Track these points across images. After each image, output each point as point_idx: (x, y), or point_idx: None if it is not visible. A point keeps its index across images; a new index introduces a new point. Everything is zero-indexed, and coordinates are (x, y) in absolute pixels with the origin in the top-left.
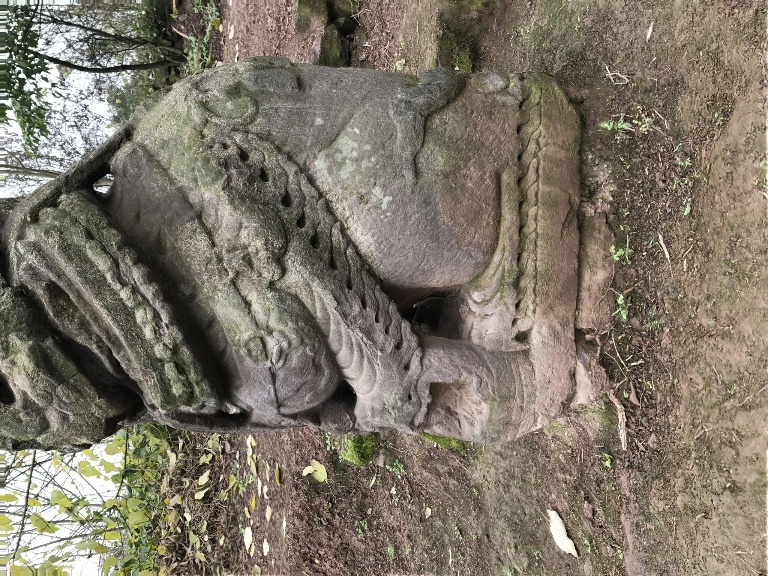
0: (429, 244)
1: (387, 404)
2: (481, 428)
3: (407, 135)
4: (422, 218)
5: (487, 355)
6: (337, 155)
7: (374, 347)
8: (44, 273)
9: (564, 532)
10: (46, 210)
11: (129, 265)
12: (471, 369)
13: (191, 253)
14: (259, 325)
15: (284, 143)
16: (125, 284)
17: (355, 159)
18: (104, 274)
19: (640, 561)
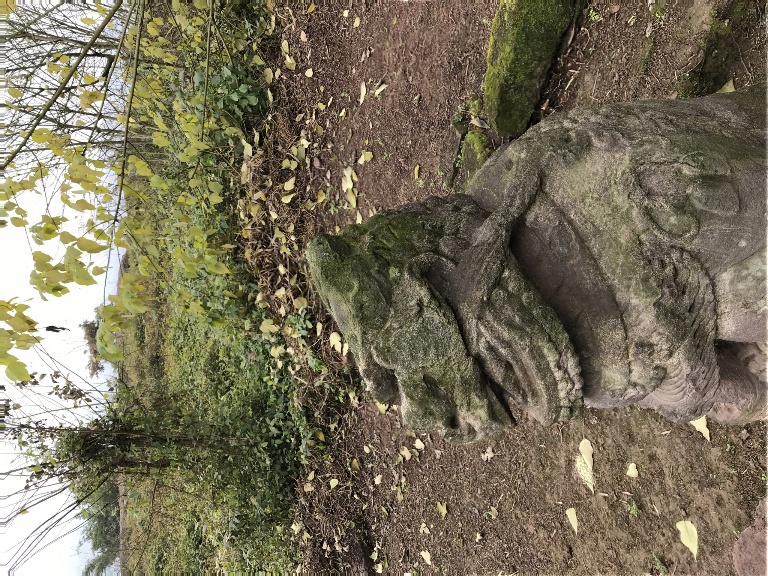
0: None
1: (677, 411)
2: (725, 419)
3: None
4: None
5: (758, 384)
6: (743, 271)
7: (693, 388)
8: (503, 355)
9: (703, 421)
10: (499, 292)
11: (568, 356)
12: (745, 396)
13: (606, 339)
14: (630, 382)
15: (707, 259)
16: (560, 367)
17: (757, 278)
18: (549, 362)
19: None
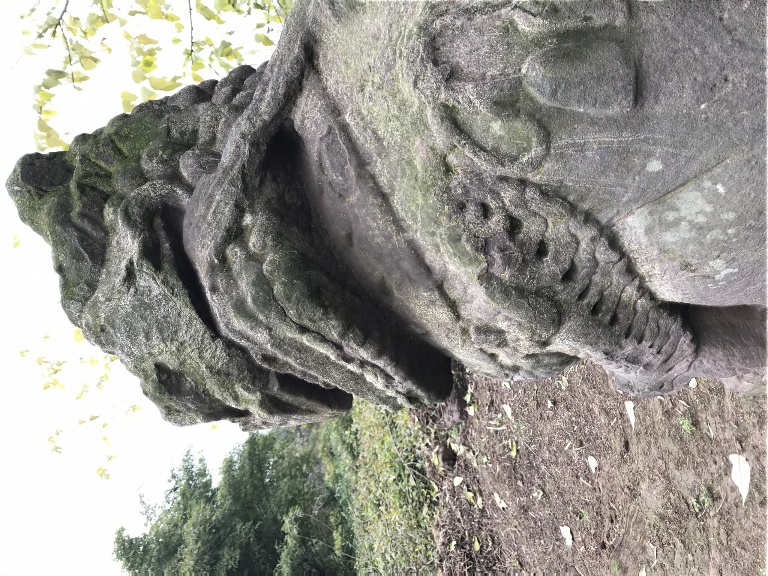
0: (766, 298)
1: (632, 384)
2: (732, 388)
3: None
4: None
5: None
6: (669, 213)
7: (637, 365)
8: None
9: None
10: (234, 250)
11: (355, 348)
12: (750, 369)
13: (428, 318)
14: (504, 365)
15: (583, 197)
16: (351, 358)
17: (699, 225)
18: (326, 354)
19: None
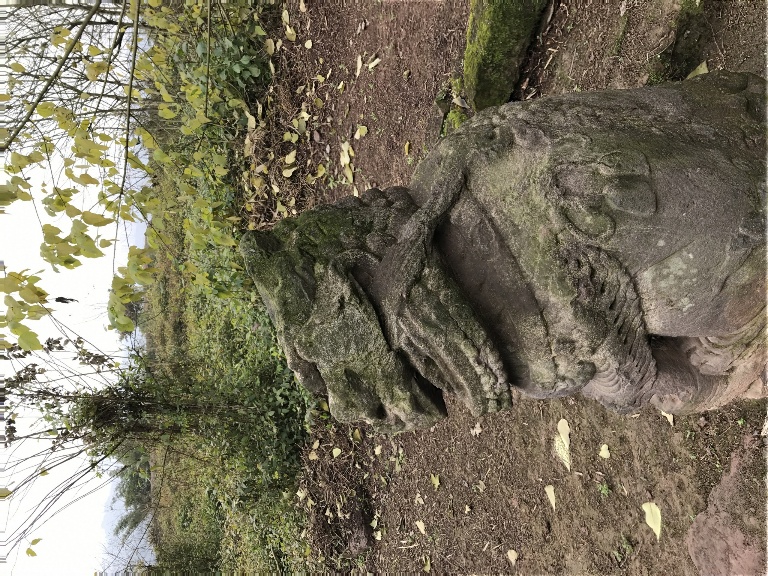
0: (703, 327)
1: (616, 402)
2: (669, 410)
3: (732, 264)
4: (708, 315)
5: (699, 377)
6: (665, 270)
7: (627, 381)
8: (422, 350)
9: None
10: (418, 289)
11: (487, 353)
12: (685, 388)
13: (527, 336)
14: (558, 375)
15: (626, 259)
16: (480, 362)
17: (679, 277)
18: (468, 358)
19: (735, 486)
